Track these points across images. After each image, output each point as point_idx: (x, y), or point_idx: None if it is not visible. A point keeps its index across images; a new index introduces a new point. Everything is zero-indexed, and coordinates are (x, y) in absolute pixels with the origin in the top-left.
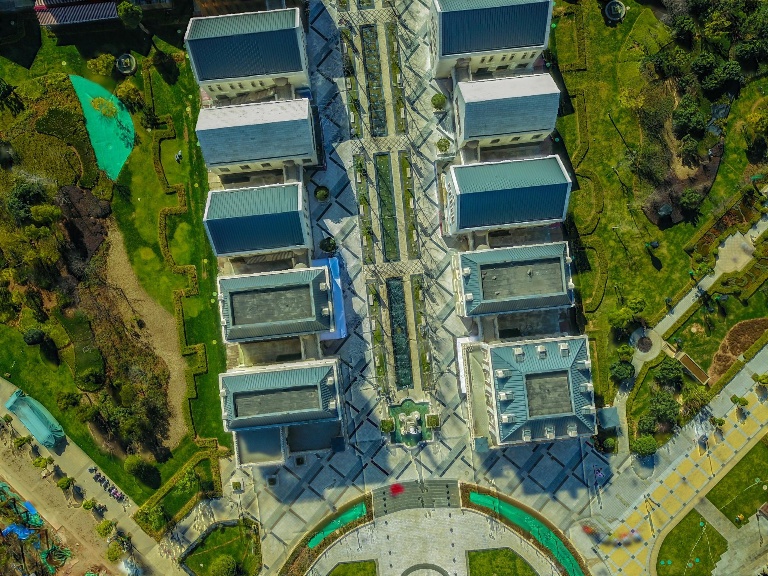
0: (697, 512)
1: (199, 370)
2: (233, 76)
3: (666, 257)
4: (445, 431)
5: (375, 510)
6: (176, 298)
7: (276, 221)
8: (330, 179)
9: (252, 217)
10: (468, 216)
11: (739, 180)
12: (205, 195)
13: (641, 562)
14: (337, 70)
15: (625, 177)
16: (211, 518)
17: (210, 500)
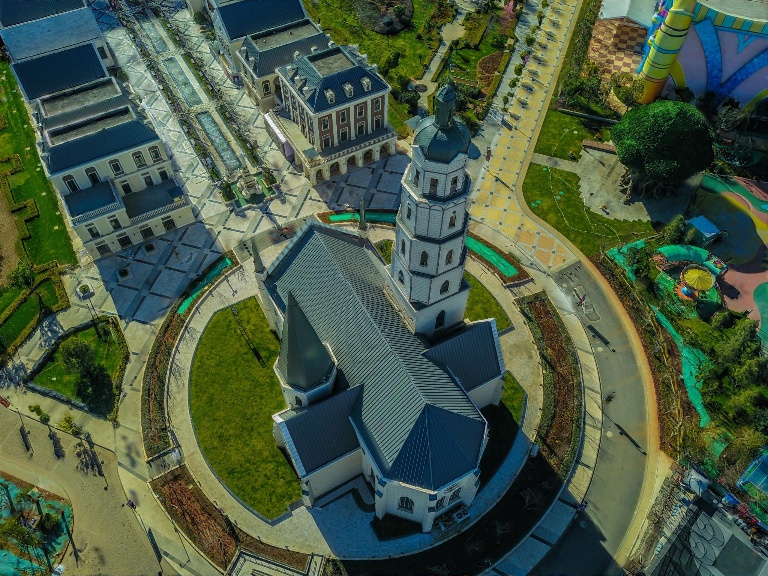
0: (535, 164)
1: (30, 216)
2: (31, 20)
3: (406, 45)
4: (286, 186)
5: (240, 258)
6: (1, 177)
7: (75, 57)
8: (130, 80)
9: (53, 55)
10: (233, 28)
11: (430, 4)
12: (23, 114)
13: (515, 211)
14: (121, 34)
15: (353, 23)
16: (60, 330)
17: (56, 315)
